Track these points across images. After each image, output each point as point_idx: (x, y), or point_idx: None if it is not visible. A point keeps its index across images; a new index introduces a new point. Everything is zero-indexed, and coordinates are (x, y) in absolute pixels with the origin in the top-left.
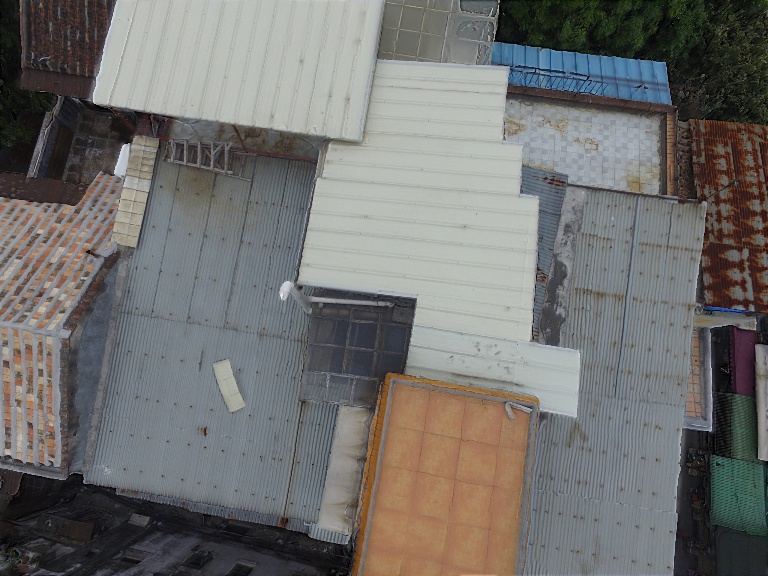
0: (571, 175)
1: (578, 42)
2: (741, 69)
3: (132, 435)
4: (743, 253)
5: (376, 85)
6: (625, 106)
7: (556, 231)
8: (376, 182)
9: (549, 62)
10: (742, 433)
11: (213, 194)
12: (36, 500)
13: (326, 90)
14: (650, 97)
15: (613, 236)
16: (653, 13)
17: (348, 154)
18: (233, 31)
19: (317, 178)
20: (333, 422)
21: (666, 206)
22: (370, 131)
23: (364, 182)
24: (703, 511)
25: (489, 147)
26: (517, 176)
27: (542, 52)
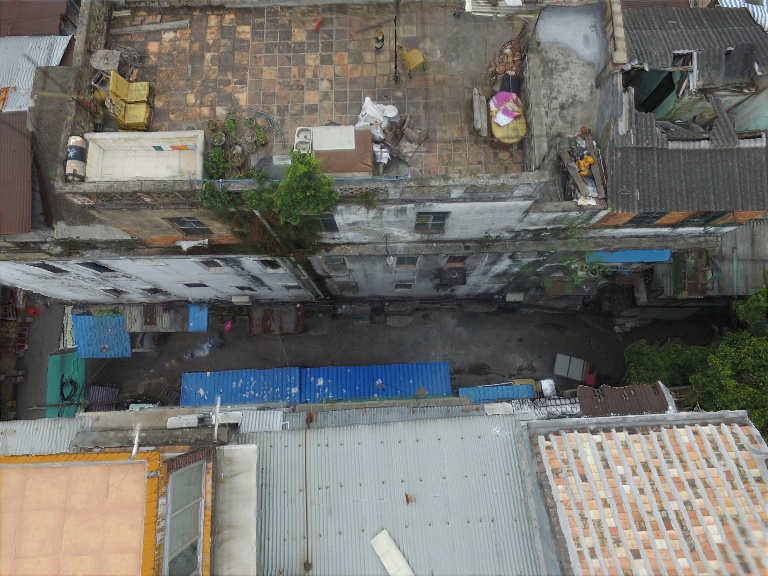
0: None
1: None
2: None
3: (484, 475)
4: None
5: None
6: None
7: None
8: None
9: None
10: None
11: None
12: (616, 290)
13: None
14: None
15: None
16: None
17: None
18: None
19: None
20: (270, 547)
21: None
22: None
23: None
24: (5, 411)
25: None
26: None
27: None
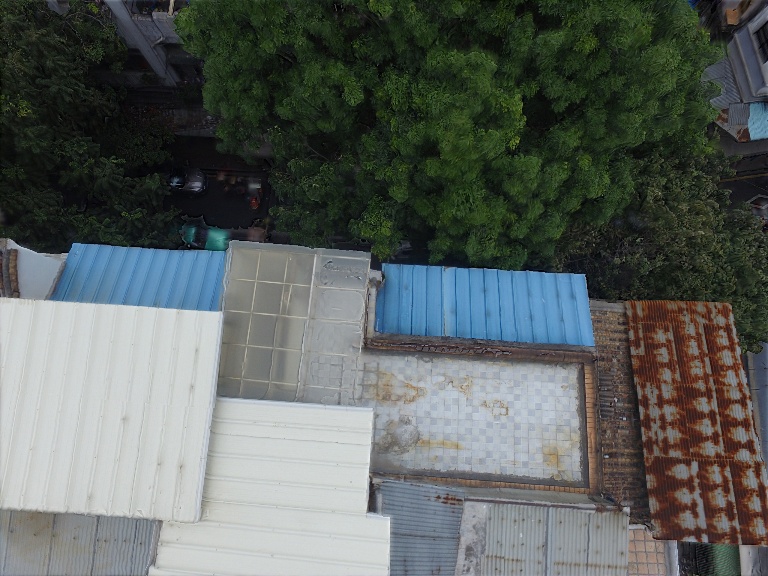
0: (478, 451)
1: (486, 255)
2: (679, 234)
3: None
4: (692, 467)
5: (218, 433)
6: (536, 358)
7: (456, 557)
8: (218, 575)
9: (454, 286)
10: (724, 551)
11: (53, 534)
12: None
13: (153, 457)
14: (568, 326)
15: (523, 557)
16: (571, 205)
17: (185, 532)
18: (39, 386)
19: (149, 567)
20: None
21: (582, 516)
22: (211, 499)
23: (204, 575)
24: None
25: (350, 523)
26: (384, 566)
27: (446, 272)
